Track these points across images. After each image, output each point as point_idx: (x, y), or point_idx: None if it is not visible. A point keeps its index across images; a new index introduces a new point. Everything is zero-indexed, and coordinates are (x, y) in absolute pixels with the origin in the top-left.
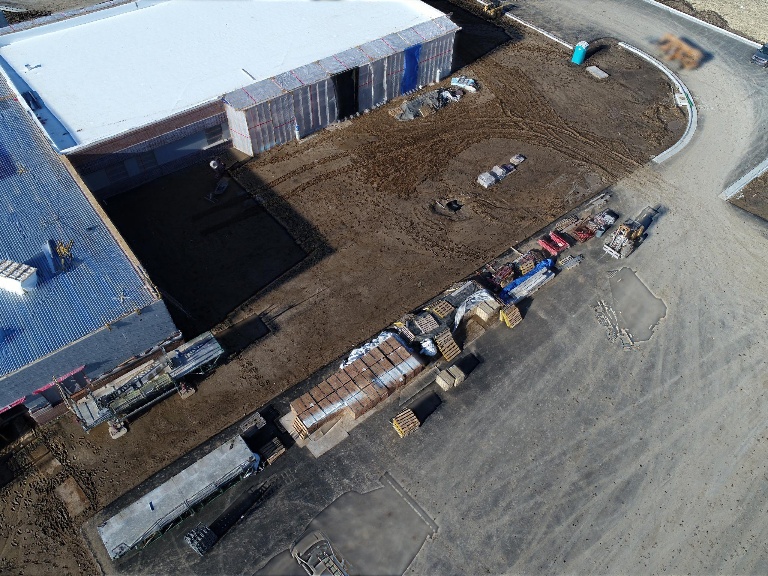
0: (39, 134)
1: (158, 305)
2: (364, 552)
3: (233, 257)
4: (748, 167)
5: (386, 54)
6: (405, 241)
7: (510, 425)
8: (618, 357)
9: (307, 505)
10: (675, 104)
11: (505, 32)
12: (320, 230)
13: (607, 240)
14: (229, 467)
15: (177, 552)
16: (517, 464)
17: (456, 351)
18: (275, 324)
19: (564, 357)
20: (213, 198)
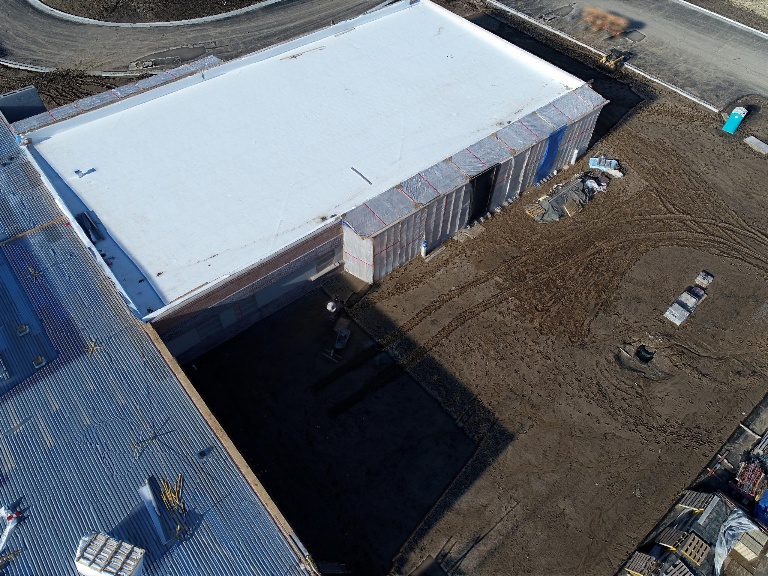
0: (106, 281)
1: None
2: None
3: (379, 454)
4: None
5: (530, 143)
6: (599, 417)
7: None
8: None
9: None
10: None
11: (632, 90)
12: (484, 402)
13: None
14: None
15: None
16: None
17: None
18: (461, 574)
19: None
20: (334, 354)
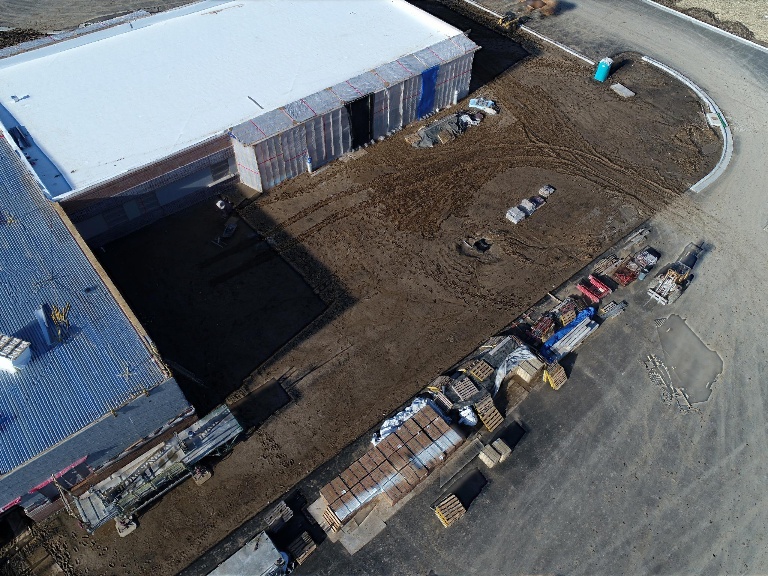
0: (29, 176)
1: (169, 384)
2: None
3: (246, 311)
4: None
5: (403, 78)
6: (433, 288)
7: (565, 508)
8: (676, 422)
9: None
10: (707, 125)
11: (522, 47)
12: (340, 277)
13: (652, 284)
14: (255, 573)
15: None
16: (576, 557)
17: (498, 419)
18: (296, 390)
19: (617, 423)
20: (221, 242)
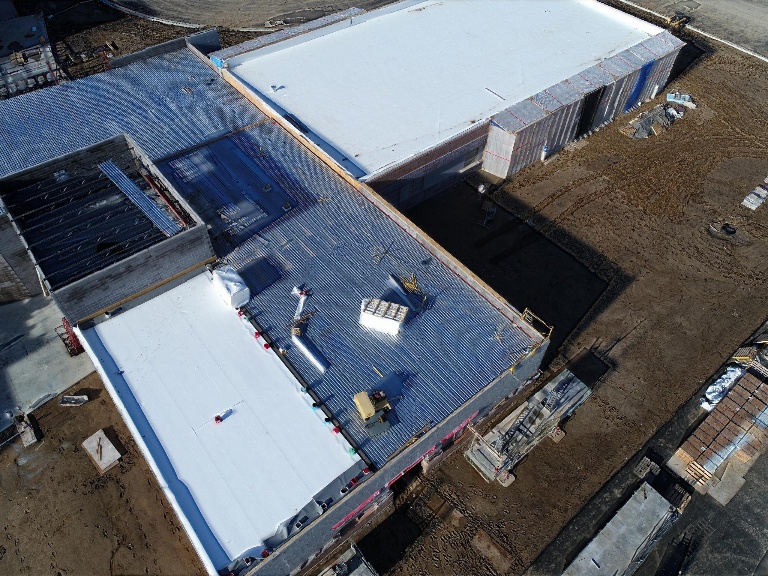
0: (317, 160)
1: (545, 346)
2: None
3: (534, 287)
4: None
5: (627, 72)
6: (699, 268)
7: None
8: None
9: (740, 558)
10: None
11: (695, 45)
12: (608, 257)
13: None
14: (654, 519)
15: None
16: None
17: None
18: (611, 359)
19: None
20: (486, 224)
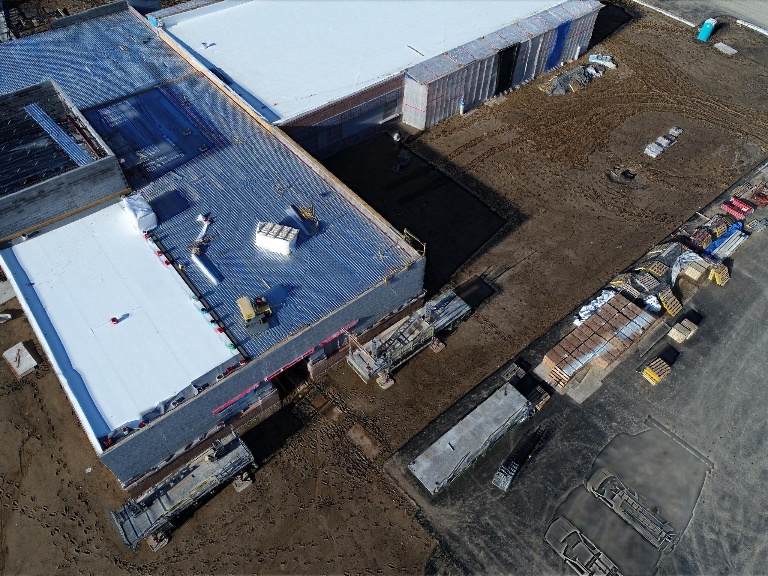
0: (238, 108)
1: (421, 262)
2: (653, 486)
3: (437, 224)
4: None
5: (543, 30)
6: (594, 208)
7: (750, 373)
8: None
9: (586, 446)
10: None
11: (625, 11)
12: (510, 198)
13: None
14: (510, 411)
15: (481, 488)
16: None
17: (678, 307)
18: (498, 284)
19: None
20: (400, 169)
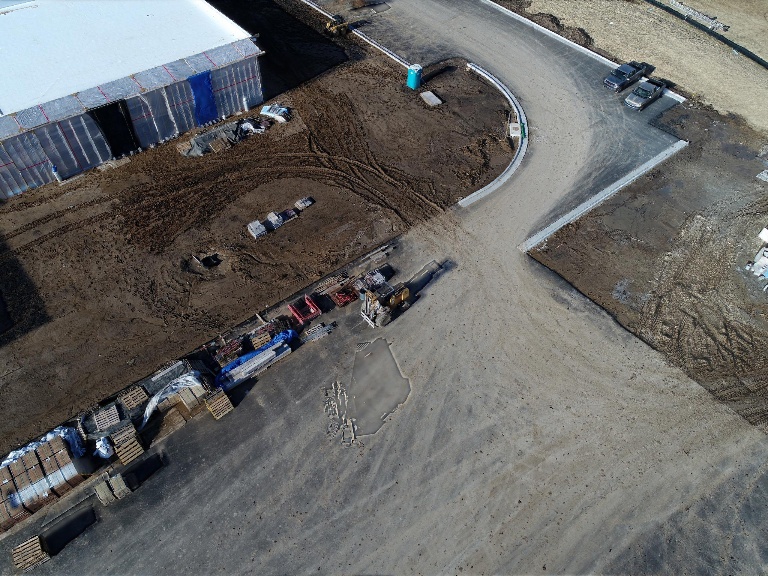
0: None
1: None
2: None
3: None
4: (563, 211)
5: (163, 84)
6: (136, 306)
7: (167, 552)
8: (331, 457)
9: None
10: (506, 135)
11: (344, 52)
12: (41, 293)
13: (363, 306)
14: None
15: None
16: None
17: (137, 452)
18: None
19: (266, 457)
20: None
